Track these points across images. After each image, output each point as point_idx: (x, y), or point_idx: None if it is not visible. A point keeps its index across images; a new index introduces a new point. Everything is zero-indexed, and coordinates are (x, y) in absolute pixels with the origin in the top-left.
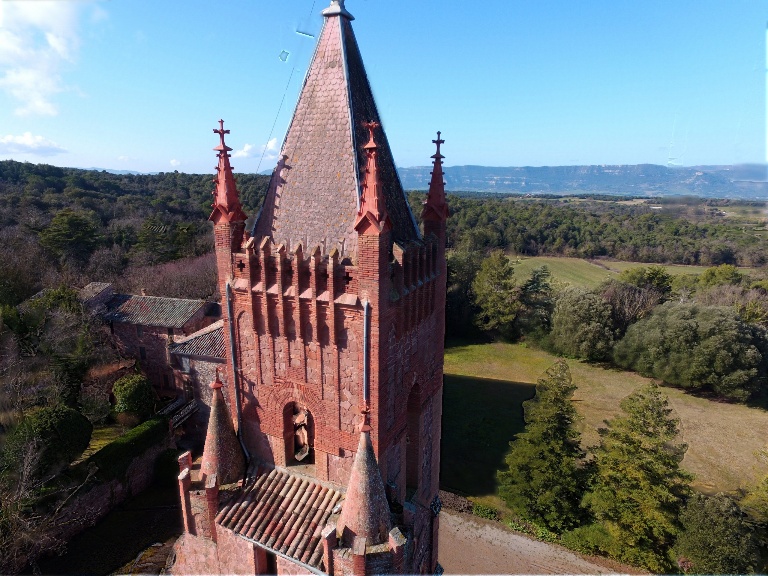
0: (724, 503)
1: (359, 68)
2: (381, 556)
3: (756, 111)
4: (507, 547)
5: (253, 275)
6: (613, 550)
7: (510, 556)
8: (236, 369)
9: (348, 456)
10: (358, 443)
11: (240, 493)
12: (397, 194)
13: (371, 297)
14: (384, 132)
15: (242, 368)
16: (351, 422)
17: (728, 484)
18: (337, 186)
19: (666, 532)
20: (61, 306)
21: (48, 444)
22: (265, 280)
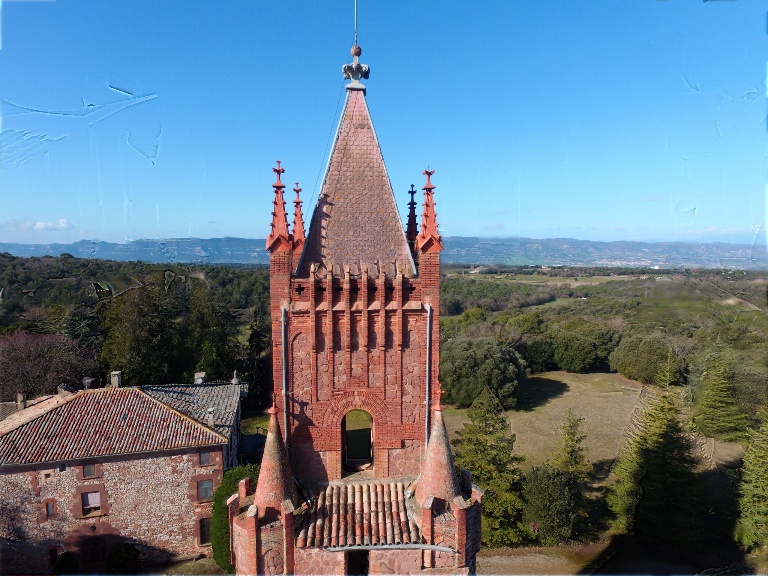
0: (550, 468)
1: None
2: (471, 509)
3: (484, 194)
4: None
5: (316, 296)
6: (485, 537)
7: None
8: (287, 393)
9: (409, 446)
10: (419, 430)
11: (308, 515)
12: None
13: (433, 301)
14: None
15: (293, 391)
16: (412, 413)
17: (527, 468)
18: (382, 219)
19: (516, 508)
20: None
21: None
22: (331, 299)
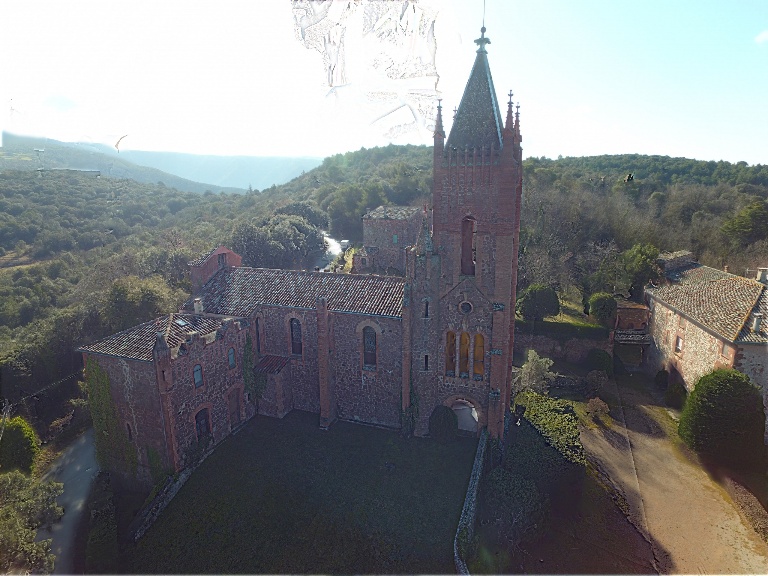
0: None
1: (483, 71)
2: None
3: None
4: (746, 574)
5: None
6: None
7: (734, 575)
8: None
9: None
10: None
11: None
12: (490, 125)
13: None
14: (492, 97)
15: None
16: None
17: None
18: None
19: None
20: (596, 241)
21: (530, 298)
22: None
